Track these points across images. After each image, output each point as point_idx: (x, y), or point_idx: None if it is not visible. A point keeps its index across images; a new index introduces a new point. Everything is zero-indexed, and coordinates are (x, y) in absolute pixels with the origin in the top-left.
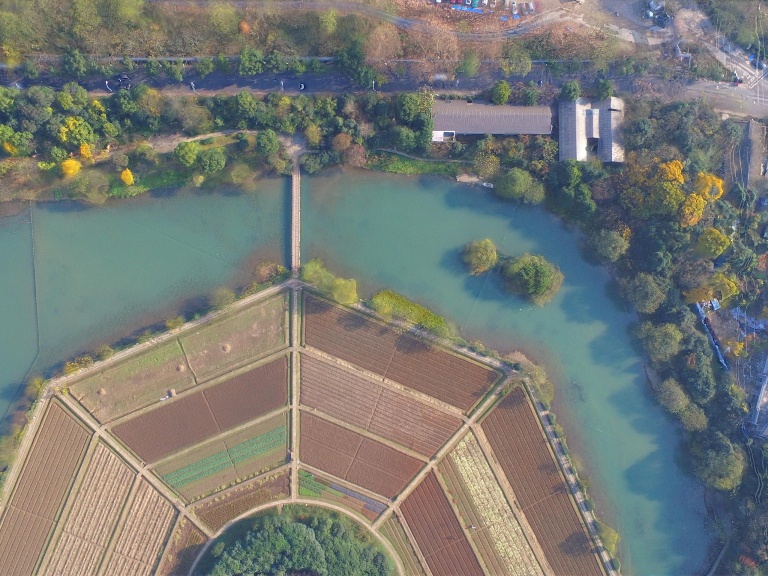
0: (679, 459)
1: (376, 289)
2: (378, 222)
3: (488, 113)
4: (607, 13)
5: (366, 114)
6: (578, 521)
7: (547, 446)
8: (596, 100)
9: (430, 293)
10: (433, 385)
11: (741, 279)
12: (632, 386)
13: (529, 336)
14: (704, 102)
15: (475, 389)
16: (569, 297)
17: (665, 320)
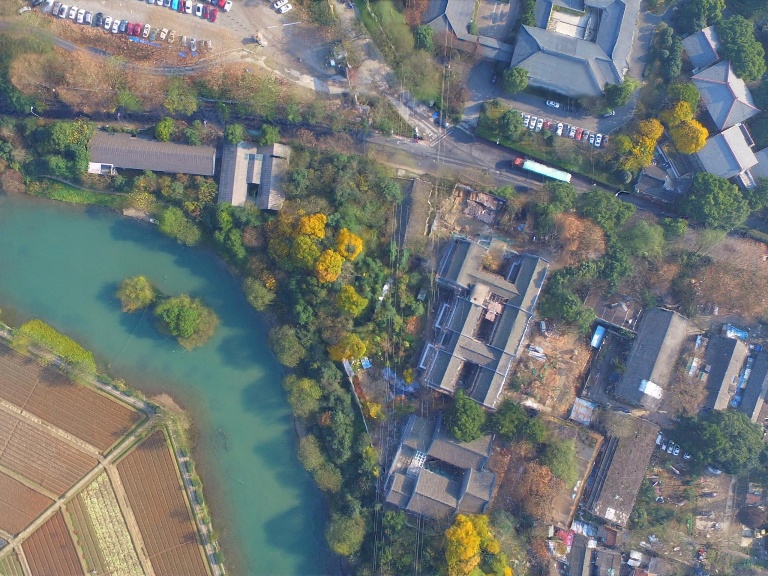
0: (318, 518)
1: (26, 318)
2: (38, 250)
3: (147, 149)
4: (290, 58)
5: (26, 139)
6: (205, 573)
7: (183, 493)
8: (259, 145)
9: (83, 326)
10: (72, 421)
11: (391, 339)
12: (279, 439)
13: (179, 379)
14: (370, 157)
15: (115, 429)
16: (225, 342)
17: (308, 375)
